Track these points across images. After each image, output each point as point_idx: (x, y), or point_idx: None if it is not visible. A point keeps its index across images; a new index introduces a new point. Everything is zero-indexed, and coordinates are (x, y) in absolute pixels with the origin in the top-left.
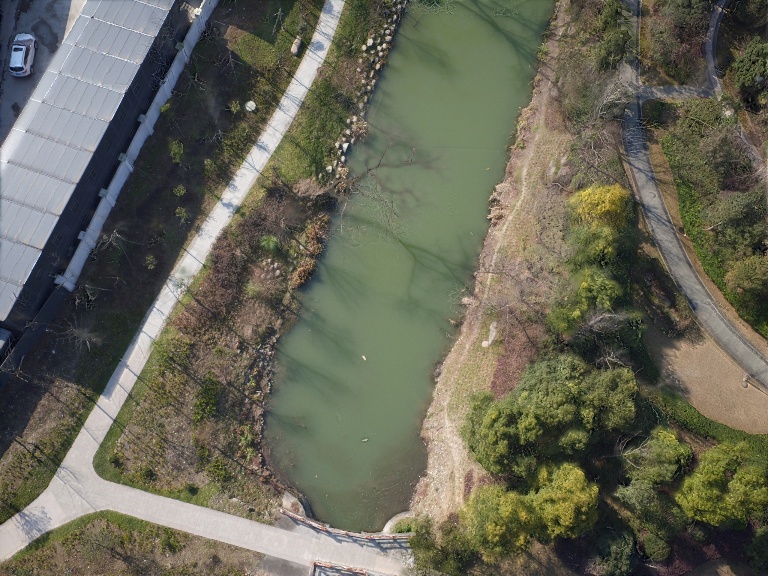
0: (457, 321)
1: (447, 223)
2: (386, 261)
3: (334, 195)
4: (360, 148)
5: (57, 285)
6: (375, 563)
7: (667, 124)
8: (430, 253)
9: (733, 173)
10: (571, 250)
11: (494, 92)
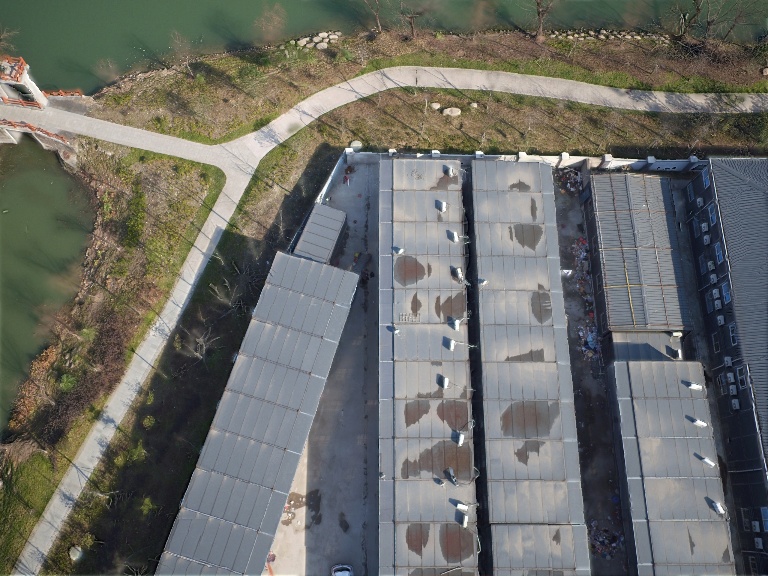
0: None
1: None
2: None
3: None
4: None
5: None
6: None
7: None
8: None
9: None
10: None
11: None
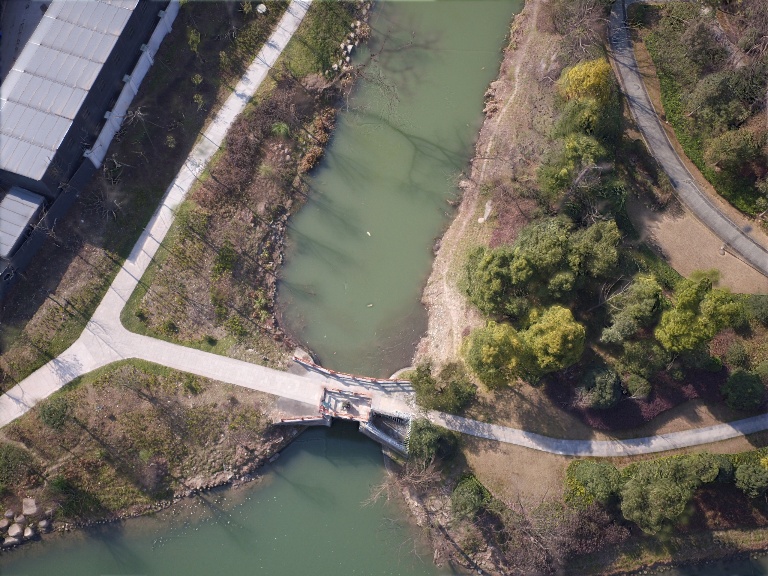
0: (455, 202)
1: (445, 116)
2: (388, 149)
3: (340, 86)
4: (364, 50)
5: (86, 158)
6: (380, 404)
7: (650, 24)
8: (429, 142)
9: (711, 63)
10: (560, 133)
11: (489, 0)
